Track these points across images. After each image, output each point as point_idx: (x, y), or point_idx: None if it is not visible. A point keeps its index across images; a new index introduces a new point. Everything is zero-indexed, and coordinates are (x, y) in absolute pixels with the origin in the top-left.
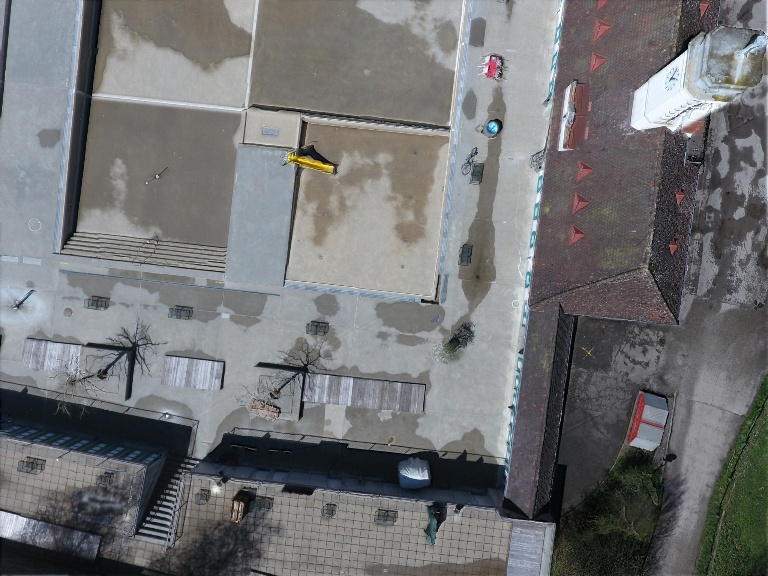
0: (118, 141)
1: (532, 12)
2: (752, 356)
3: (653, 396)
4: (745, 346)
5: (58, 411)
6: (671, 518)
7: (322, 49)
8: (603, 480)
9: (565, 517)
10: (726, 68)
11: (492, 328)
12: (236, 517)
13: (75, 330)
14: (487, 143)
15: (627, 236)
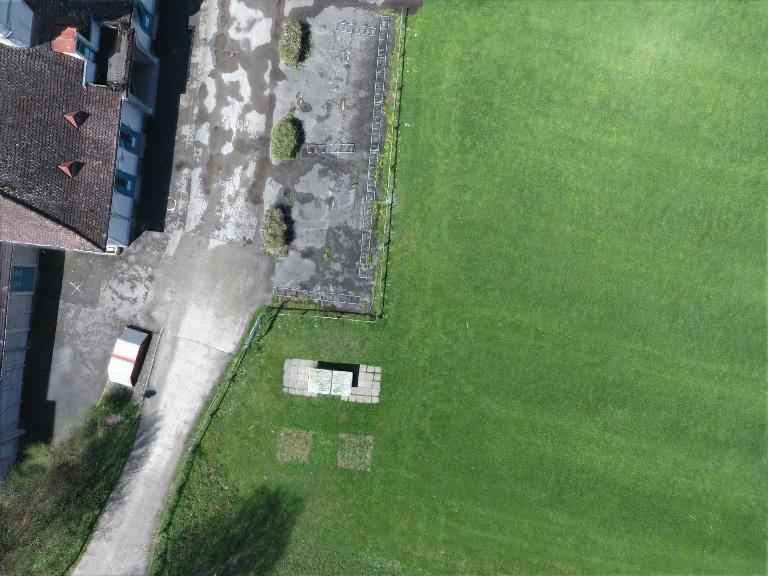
0: None
1: None
2: (241, 293)
3: (135, 331)
4: (234, 283)
5: None
6: (143, 454)
7: None
8: (90, 416)
9: None
10: None
11: None
12: None
13: None
14: None
15: None
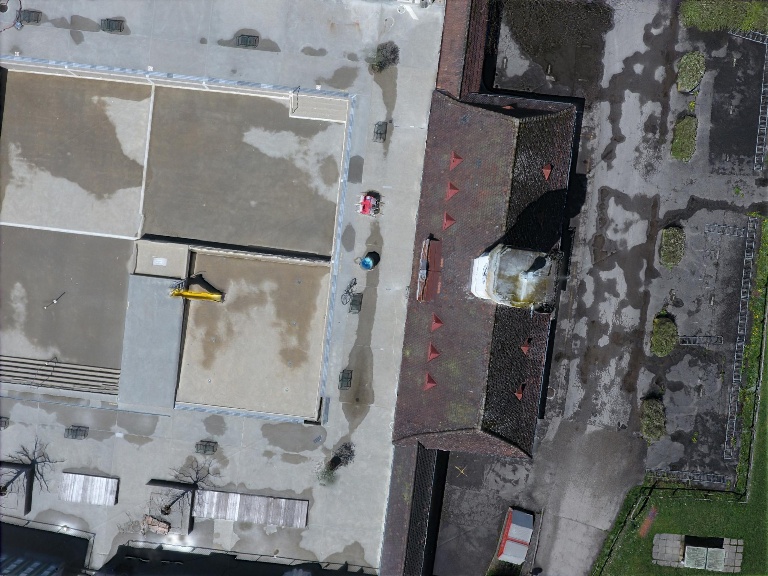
0: (18, 267)
1: (407, 151)
2: (615, 474)
3: (521, 513)
4: (609, 465)
5: None
6: None
7: (211, 182)
8: None
9: None
10: (512, 287)
11: (371, 448)
12: None
13: None
14: (366, 274)
15: (466, 395)
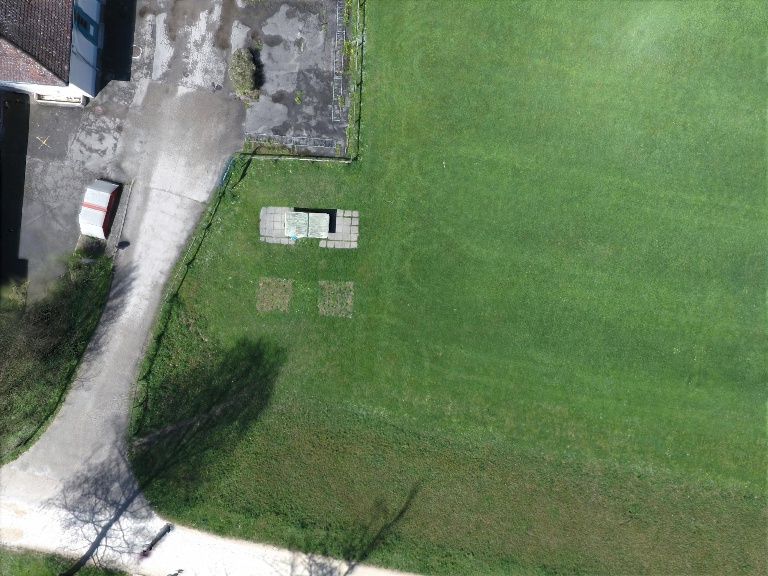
0: None
1: None
2: (212, 141)
3: (106, 183)
4: (204, 131)
5: None
6: (119, 305)
7: None
8: (63, 273)
9: (28, 313)
10: None
11: None
12: None
13: None
14: None
15: None
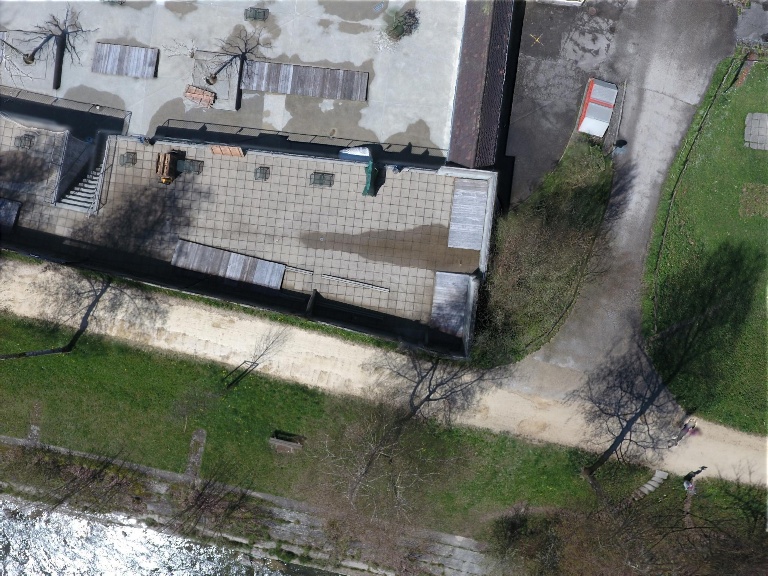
0: None
1: None
2: (704, 45)
3: (603, 81)
4: (696, 35)
5: None
6: (621, 202)
7: None
8: (552, 171)
9: (513, 210)
10: None
11: (437, 15)
12: (162, 169)
13: (1, 16)
14: None
15: None
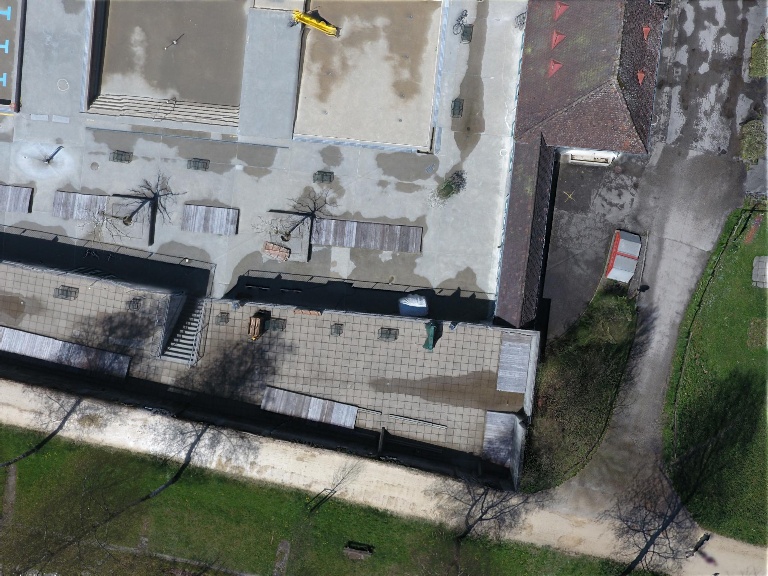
0: (138, 10)
1: None
2: (716, 198)
3: (628, 233)
4: (710, 189)
5: (87, 255)
6: (645, 341)
7: None
8: (584, 311)
9: (550, 346)
10: None
11: (482, 175)
12: (253, 332)
13: (101, 182)
14: (476, 6)
15: (599, 56)
